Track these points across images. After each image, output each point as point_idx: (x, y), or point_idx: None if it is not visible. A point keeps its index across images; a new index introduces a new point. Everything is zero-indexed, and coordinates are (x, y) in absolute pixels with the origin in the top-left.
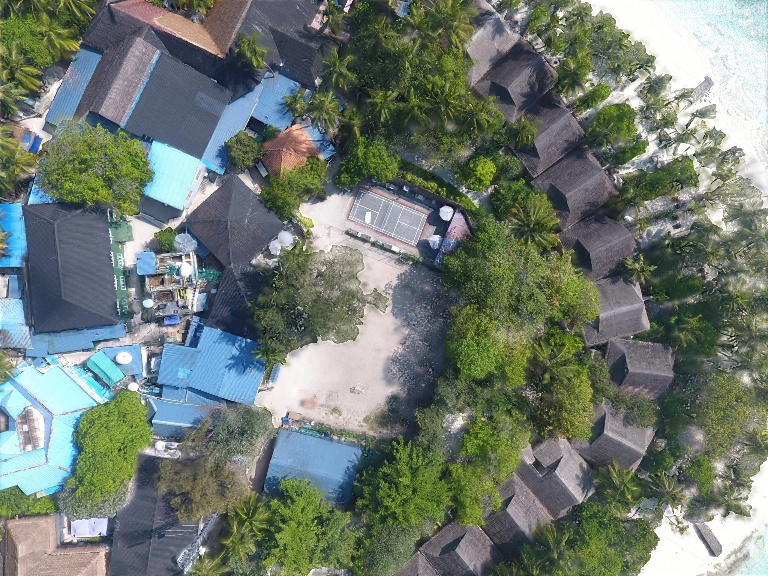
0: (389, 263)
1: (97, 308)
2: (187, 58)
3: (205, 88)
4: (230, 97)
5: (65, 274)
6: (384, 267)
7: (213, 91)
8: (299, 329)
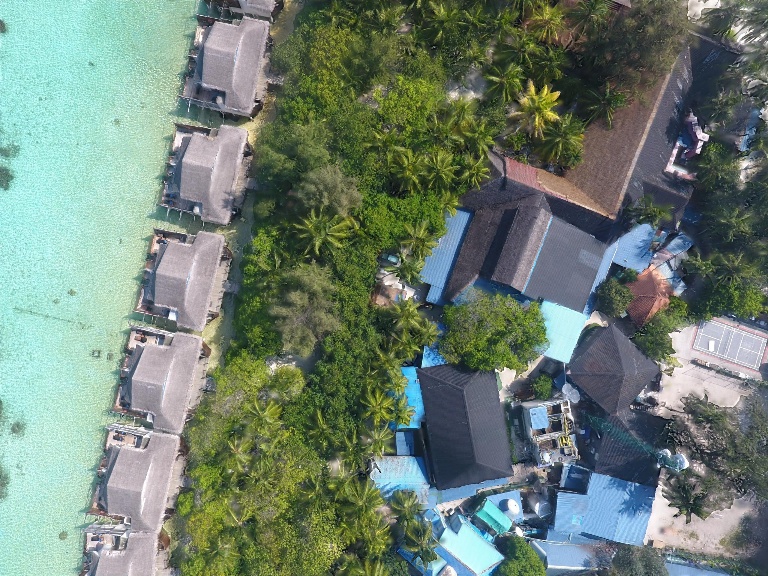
0: (734, 389)
1: (499, 465)
2: (572, 218)
3: (586, 245)
4: (605, 250)
5: (475, 438)
6: (729, 393)
7: (592, 247)
8: (741, 492)
